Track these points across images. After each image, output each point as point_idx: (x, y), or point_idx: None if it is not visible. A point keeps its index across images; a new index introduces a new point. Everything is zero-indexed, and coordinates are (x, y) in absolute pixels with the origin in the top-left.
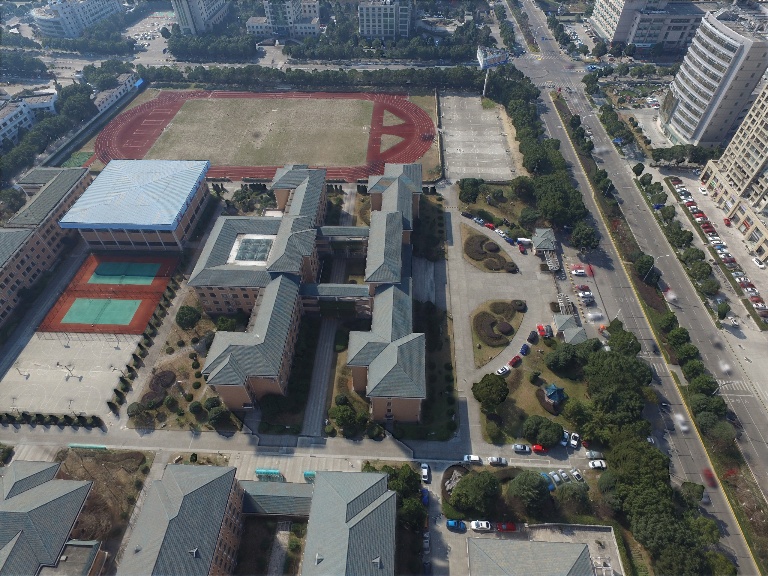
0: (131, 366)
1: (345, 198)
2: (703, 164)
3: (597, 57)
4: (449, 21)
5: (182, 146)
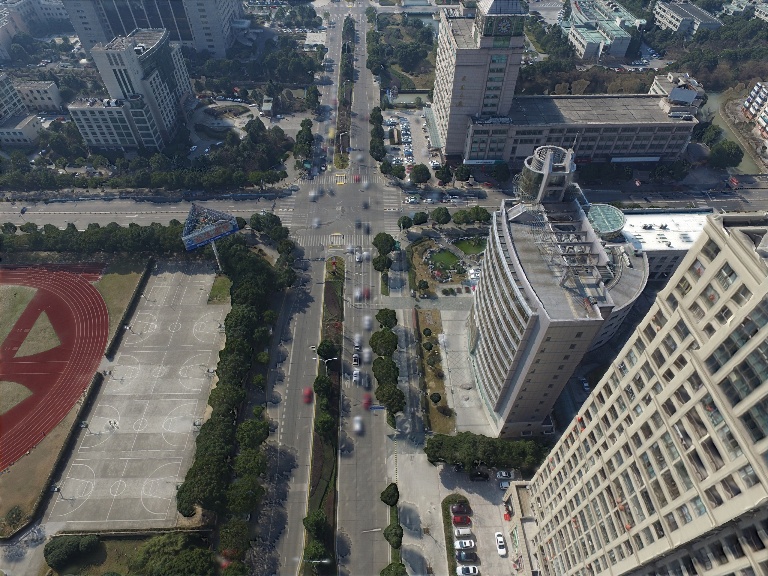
0: None
1: None
2: None
3: None
4: (243, 109)
5: None
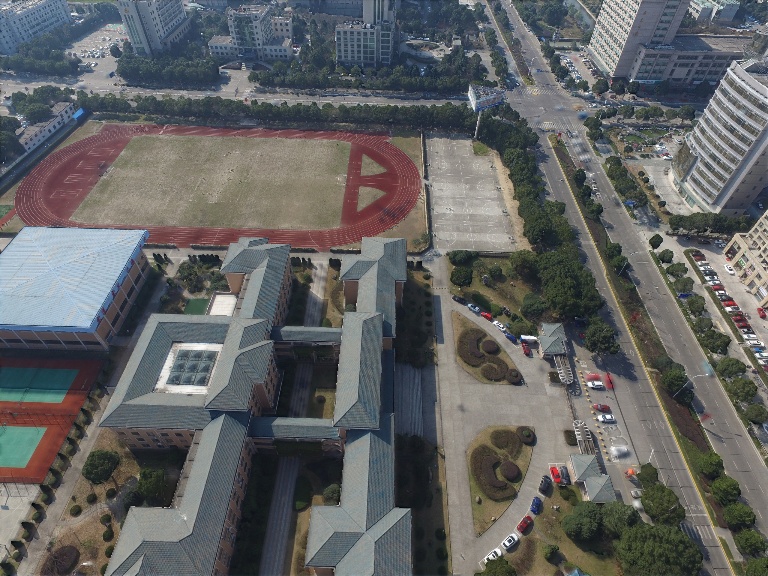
0: (20, 538)
1: (314, 274)
2: (726, 234)
3: (598, 94)
4: (435, 45)
5: (122, 198)
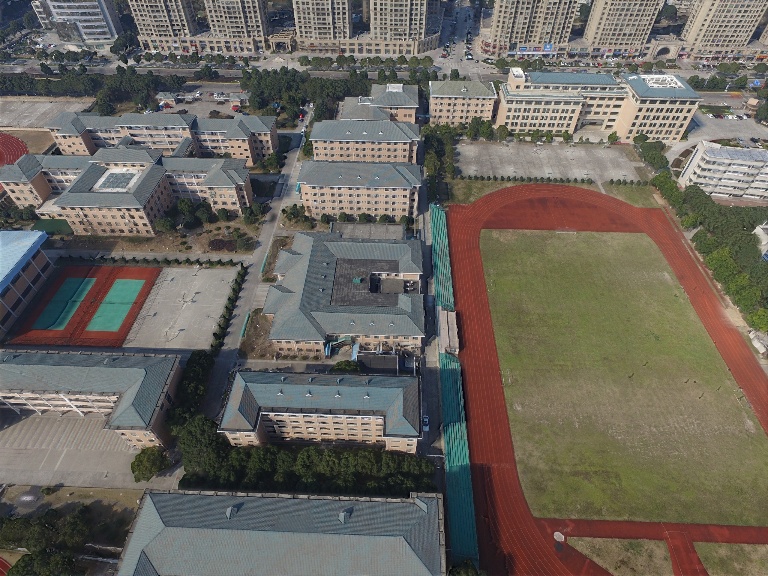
0: None
1: None
2: (133, 45)
3: None
4: None
5: None
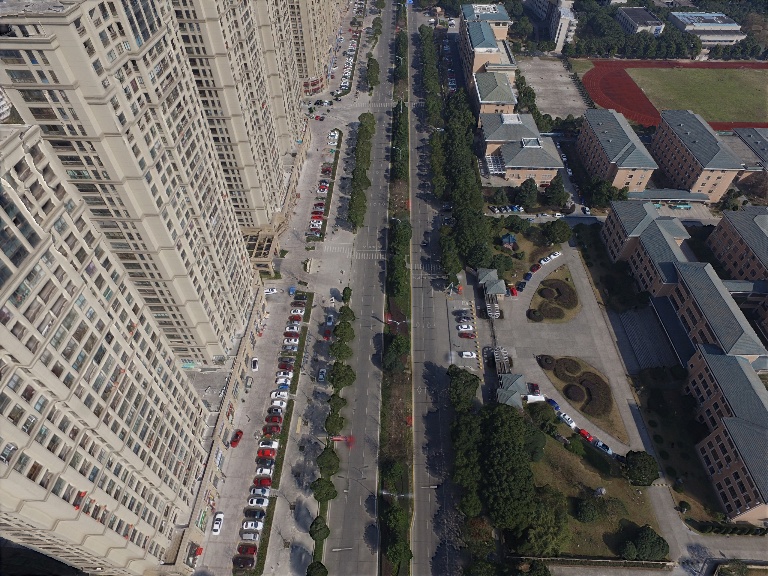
0: None
1: None
2: None
3: None
4: None
5: None
